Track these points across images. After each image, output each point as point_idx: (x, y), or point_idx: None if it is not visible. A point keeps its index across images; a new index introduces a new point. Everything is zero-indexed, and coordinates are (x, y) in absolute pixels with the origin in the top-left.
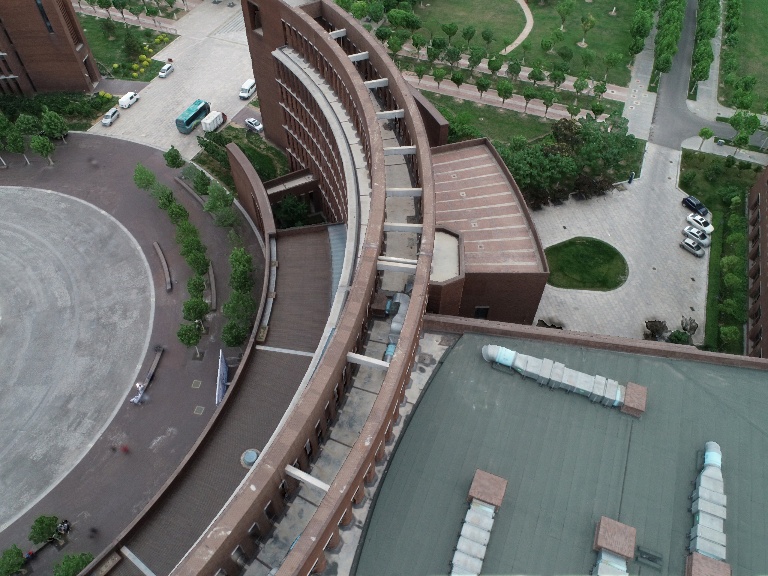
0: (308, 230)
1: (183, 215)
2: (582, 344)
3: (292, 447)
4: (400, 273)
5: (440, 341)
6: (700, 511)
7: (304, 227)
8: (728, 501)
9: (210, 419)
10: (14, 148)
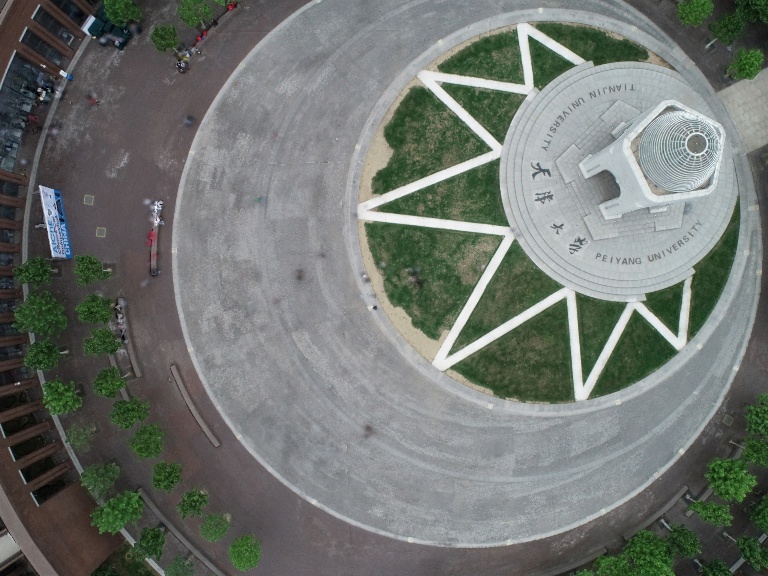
0: None
1: None
2: None
3: None
4: None
5: None
6: None
7: None
8: None
9: None
10: None
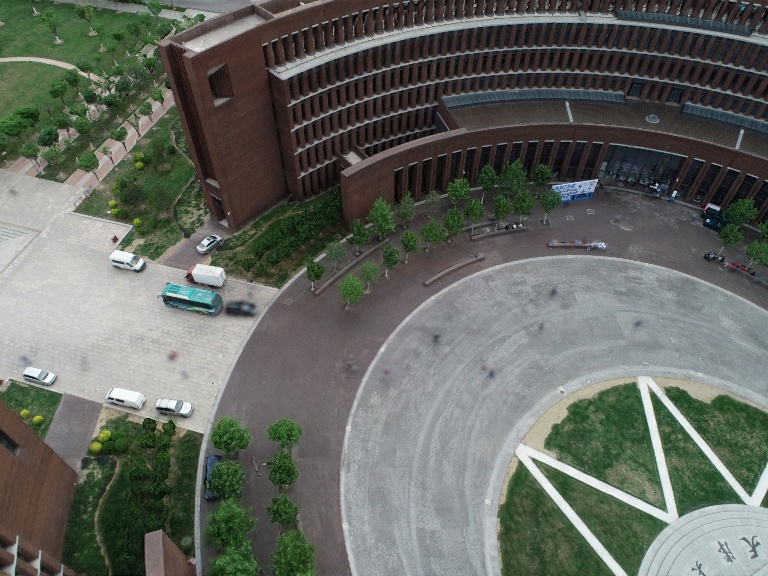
0: None
1: None
2: None
3: None
4: (559, 4)
5: None
6: None
7: None
8: None
9: (644, 130)
10: None
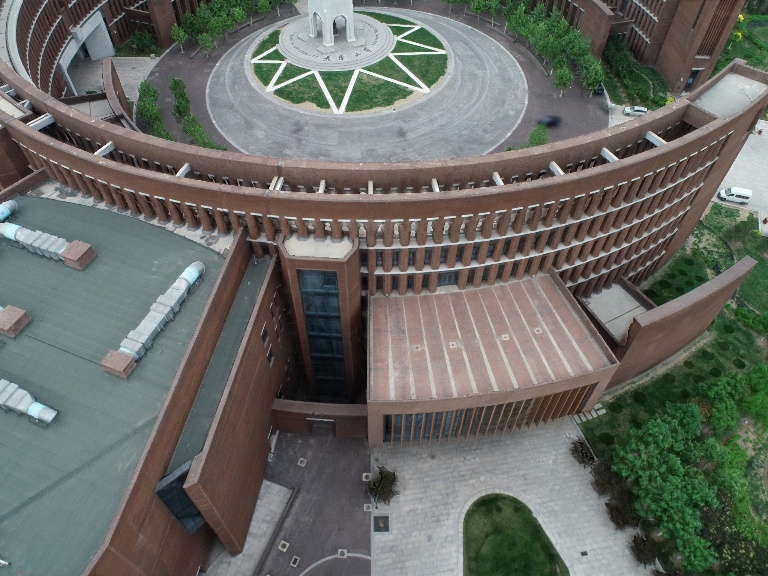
0: None
1: None
2: None
3: (115, 136)
4: None
5: None
6: None
7: None
8: (9, 422)
9: None
10: (554, 66)
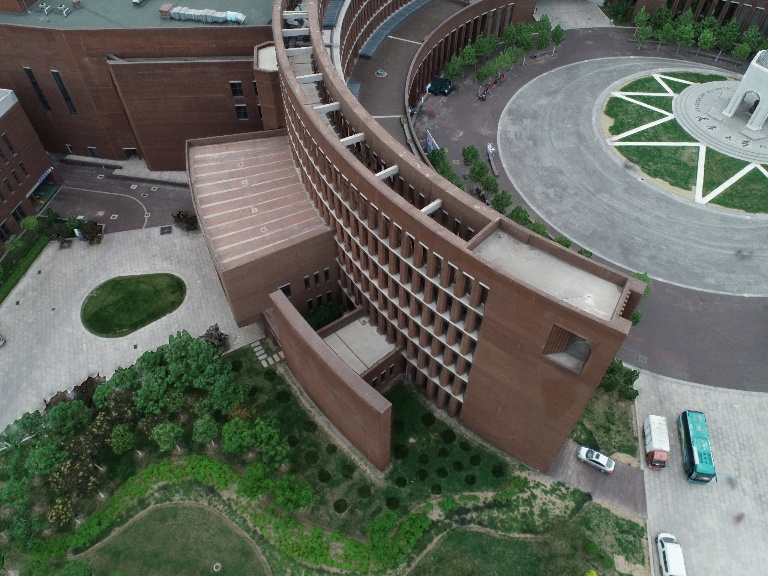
0: None
1: None
2: None
3: None
4: (299, 57)
5: None
6: None
7: None
8: None
9: None
10: None
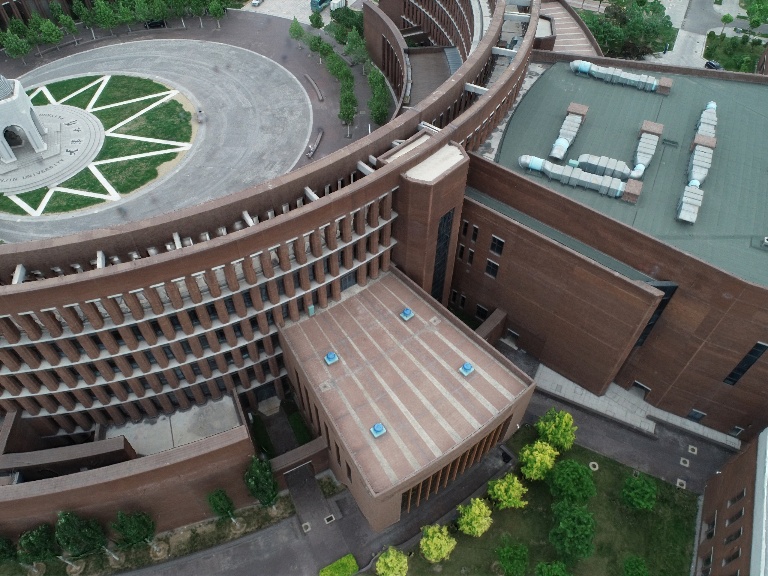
0: (430, 50)
1: (330, 51)
2: (632, 67)
3: (470, 71)
4: None
5: (541, 66)
6: (701, 123)
7: (428, 47)
8: (719, 128)
9: None
10: (196, 11)
